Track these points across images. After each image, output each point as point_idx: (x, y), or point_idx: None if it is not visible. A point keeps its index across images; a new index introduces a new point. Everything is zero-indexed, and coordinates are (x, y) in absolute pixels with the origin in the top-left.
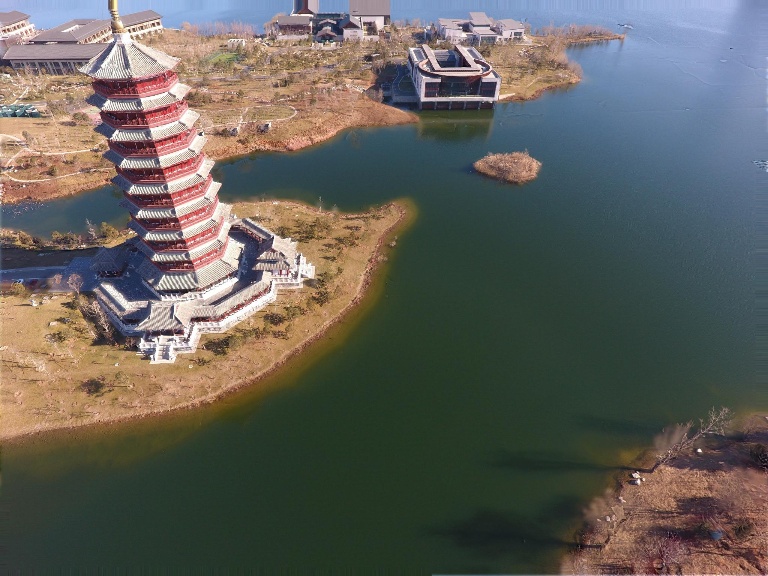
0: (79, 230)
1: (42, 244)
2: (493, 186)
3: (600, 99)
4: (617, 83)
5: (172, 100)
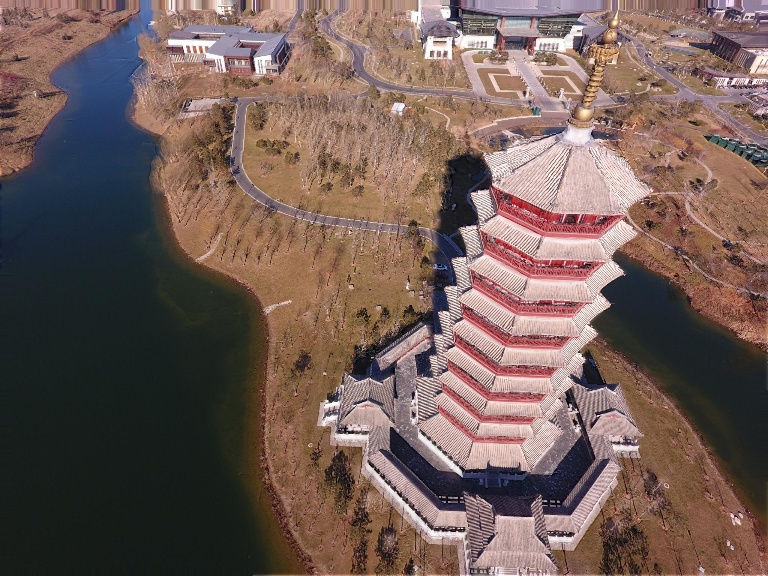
0: None
1: None
2: None
3: None
4: None
5: (529, 249)
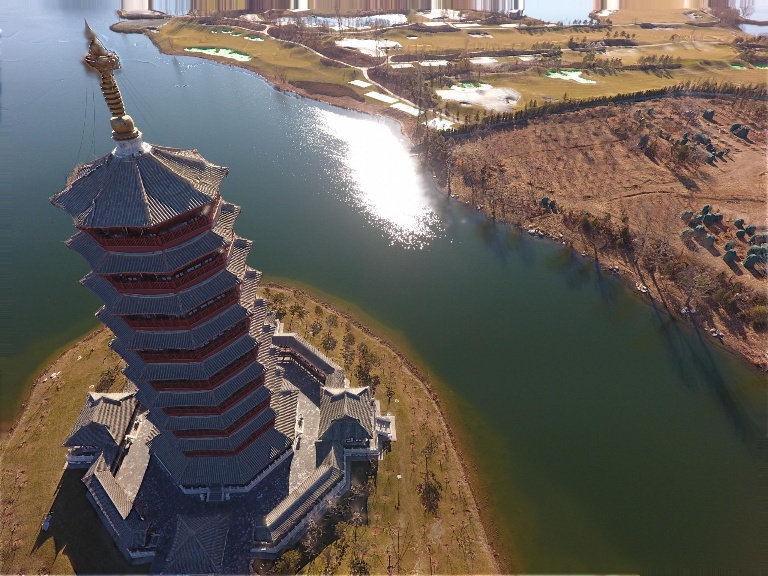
0: None
1: None
2: None
3: None
4: None
5: None
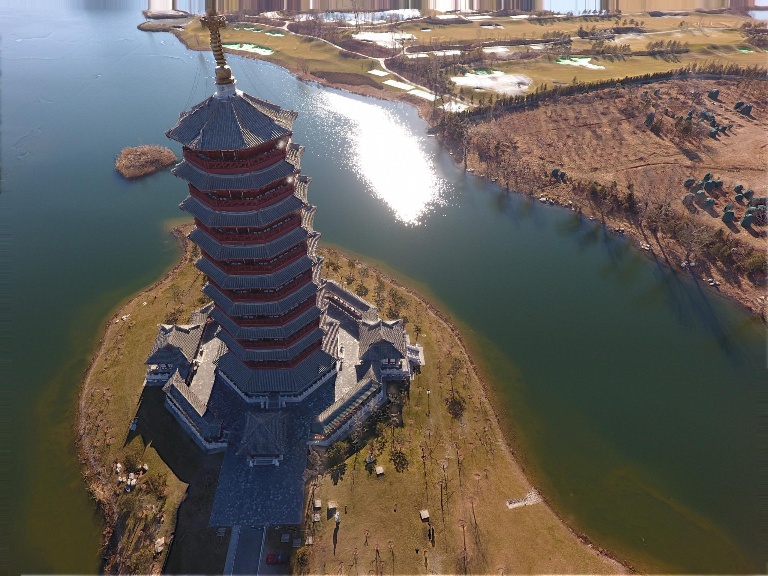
0: None
1: None
2: (153, 182)
3: (31, 99)
4: (1, 86)
5: None
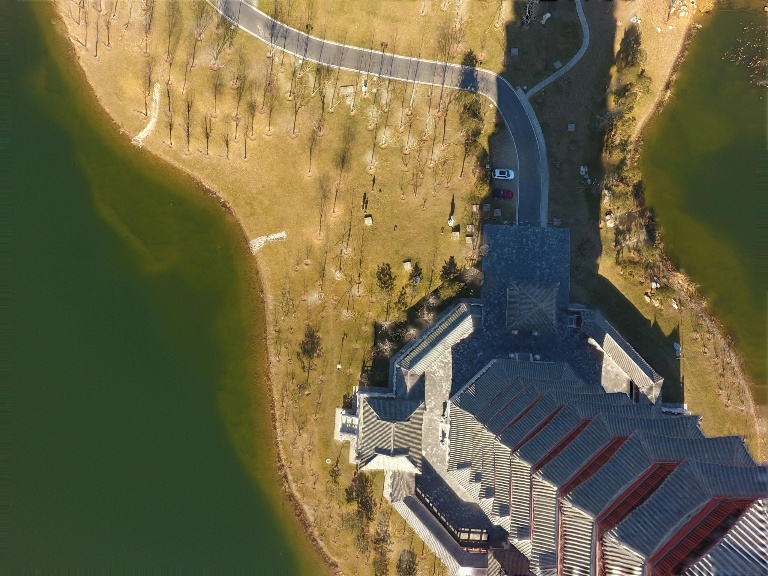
0: (681, 182)
1: (611, 161)
2: None
3: None
4: None
5: None
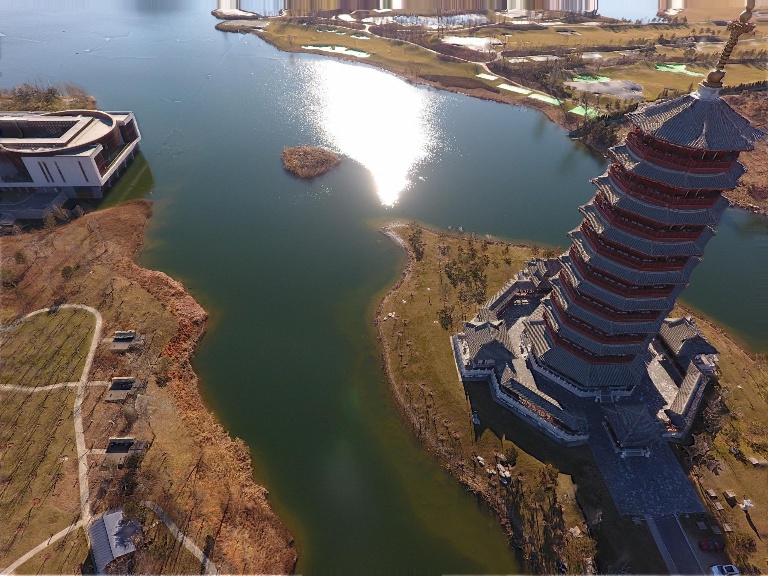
0: None
1: None
2: (318, 182)
3: (155, 99)
4: (115, 84)
5: None
